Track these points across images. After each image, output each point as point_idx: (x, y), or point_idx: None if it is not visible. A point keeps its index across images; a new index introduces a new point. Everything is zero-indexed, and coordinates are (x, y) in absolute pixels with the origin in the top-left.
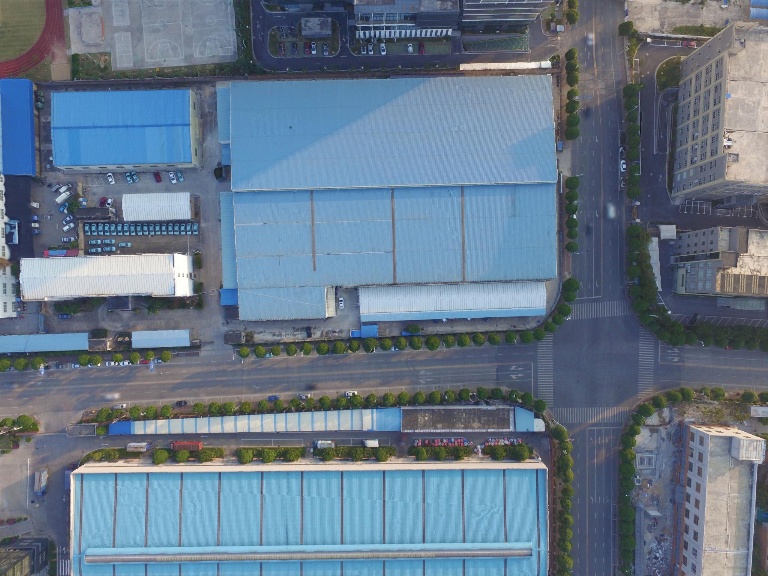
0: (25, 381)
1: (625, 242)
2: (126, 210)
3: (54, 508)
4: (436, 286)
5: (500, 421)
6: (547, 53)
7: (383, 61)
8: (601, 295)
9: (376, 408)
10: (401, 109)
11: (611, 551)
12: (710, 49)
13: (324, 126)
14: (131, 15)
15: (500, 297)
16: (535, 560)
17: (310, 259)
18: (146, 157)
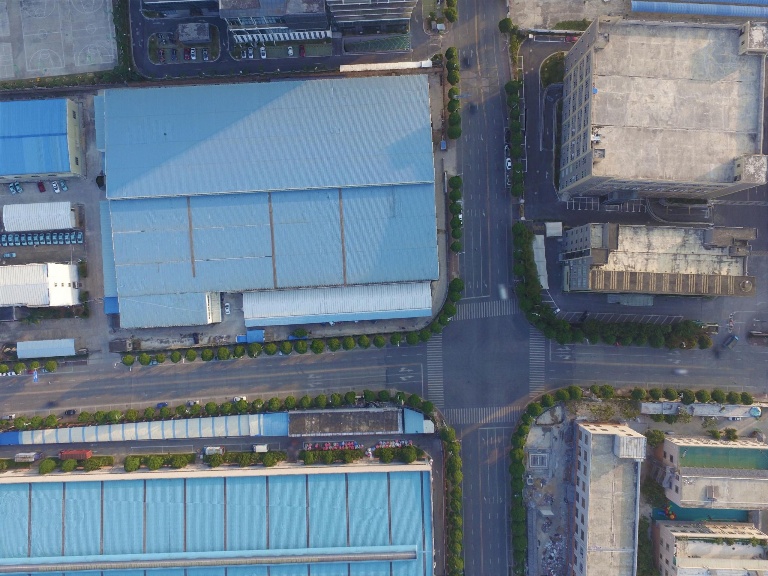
0: None
1: (513, 240)
2: (7, 221)
3: None
4: (320, 289)
5: (388, 423)
6: (429, 52)
7: (264, 65)
8: (490, 294)
9: (264, 413)
10: (276, 113)
11: (506, 552)
12: (582, 44)
13: (199, 132)
14: (11, 26)
15: (384, 299)
16: (421, 563)
17: (189, 265)
18: (24, 167)
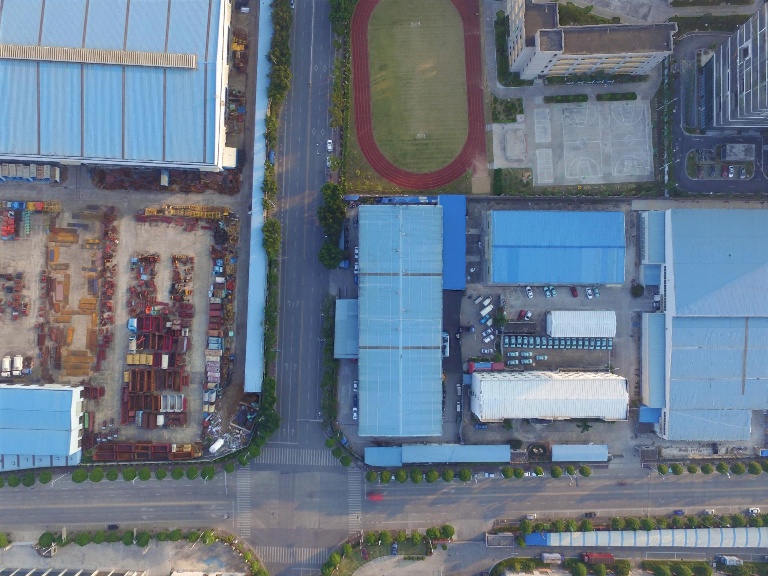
0: (438, 488)
1: None
2: (556, 327)
3: None
4: None
5: None
6: None
7: None
8: None
9: None
10: None
11: None
12: None
13: (761, 255)
14: (553, 132)
15: None
16: None
17: (740, 383)
18: (580, 277)
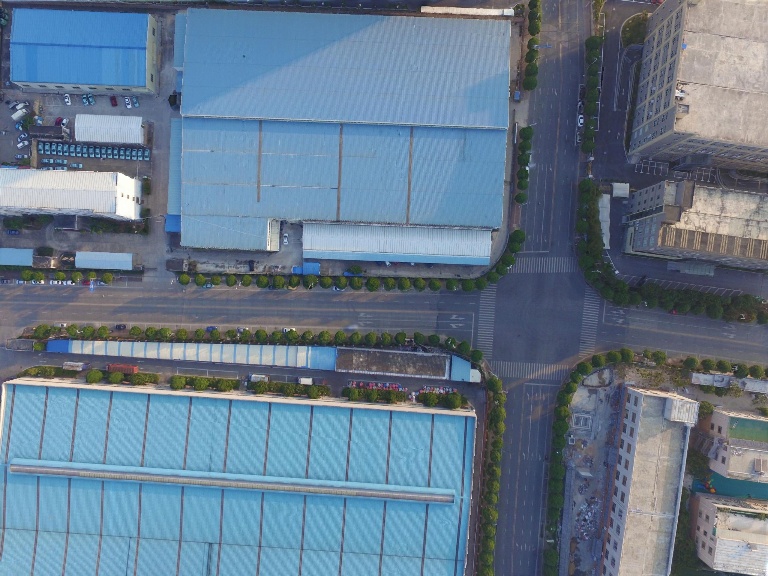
0: None
1: (577, 198)
2: (78, 130)
3: None
4: (380, 227)
5: (435, 368)
6: (512, 2)
7: None
8: (549, 250)
9: (312, 346)
10: (356, 45)
11: (540, 510)
12: (673, 1)
13: (277, 57)
14: None
15: (444, 243)
16: (457, 508)
17: (255, 190)
18: (101, 78)
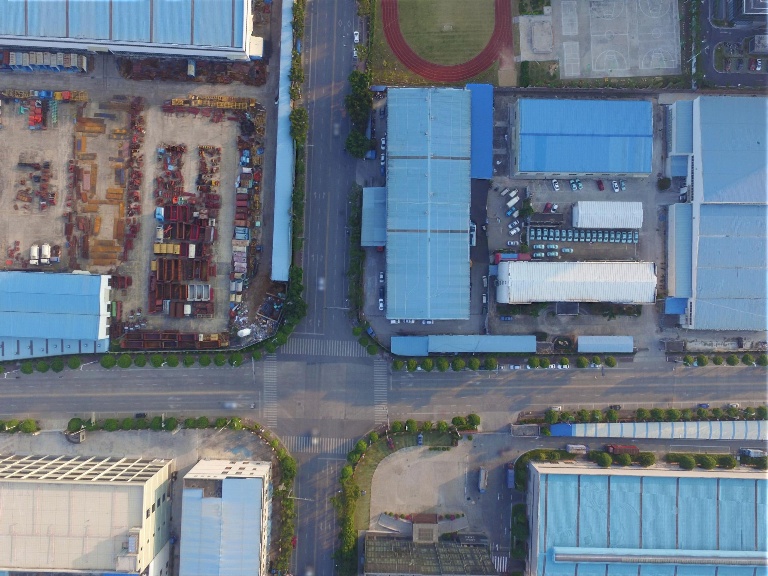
0: (464, 380)
1: None
2: (582, 217)
3: (488, 506)
4: None
5: None
6: None
7: None
8: None
9: None
10: None
11: None
12: None
13: None
14: (580, 25)
15: None
16: None
17: (767, 272)
18: (608, 166)
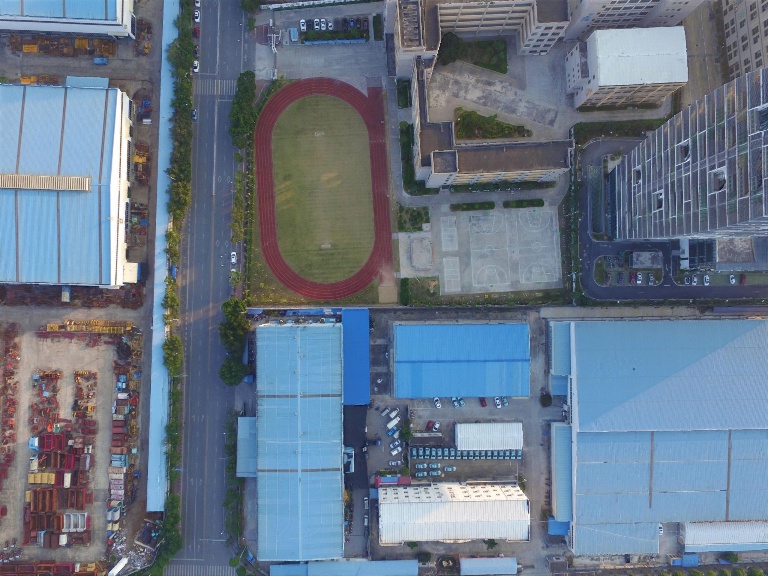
0: None
1: None
2: (461, 441)
3: None
4: None
5: None
6: None
7: (705, 291)
8: None
9: None
10: (740, 351)
11: None
12: None
13: (666, 368)
14: (459, 240)
15: None
16: None
17: (647, 497)
18: (485, 391)
